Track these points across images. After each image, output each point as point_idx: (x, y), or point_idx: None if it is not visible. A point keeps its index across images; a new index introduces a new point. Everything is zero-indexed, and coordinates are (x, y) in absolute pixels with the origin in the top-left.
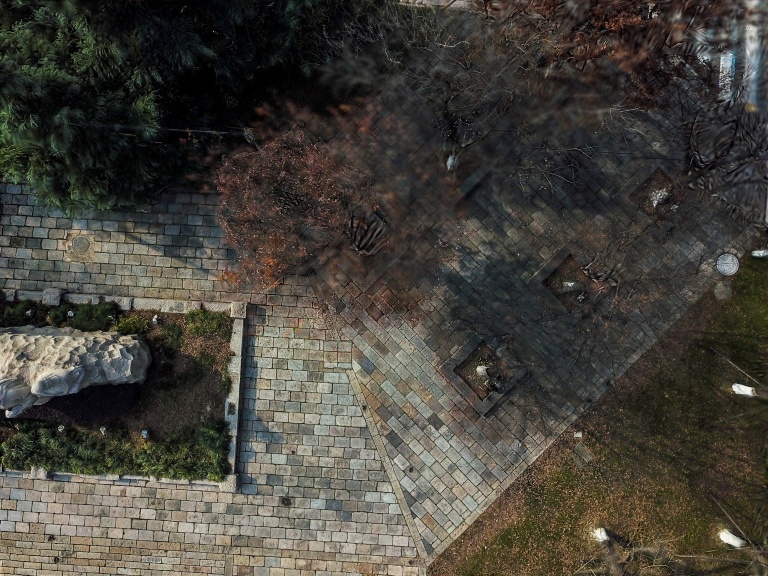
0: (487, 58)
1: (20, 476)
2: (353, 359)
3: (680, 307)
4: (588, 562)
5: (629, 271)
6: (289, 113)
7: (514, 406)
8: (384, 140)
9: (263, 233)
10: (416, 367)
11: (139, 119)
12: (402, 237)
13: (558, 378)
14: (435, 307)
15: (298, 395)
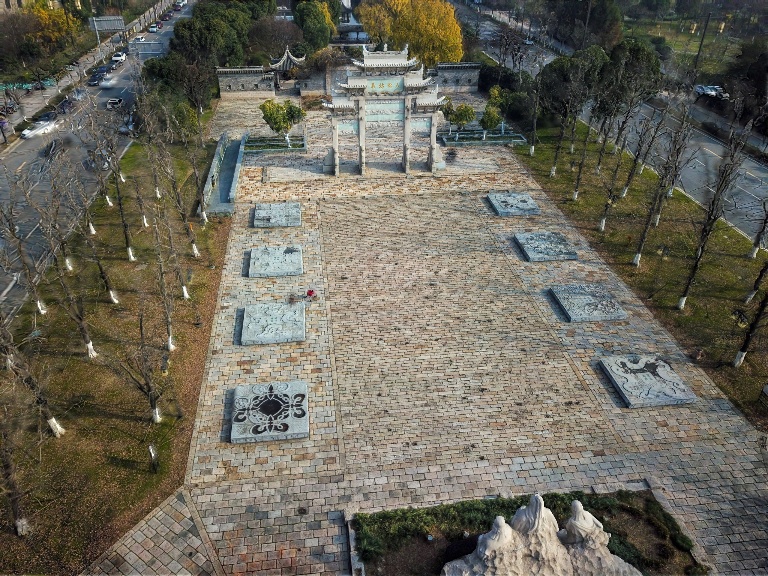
0: None
1: None
2: None
3: None
4: (42, 509)
5: None
6: None
7: None
8: None
9: None
10: None
11: None
12: None
13: None
14: None
15: None
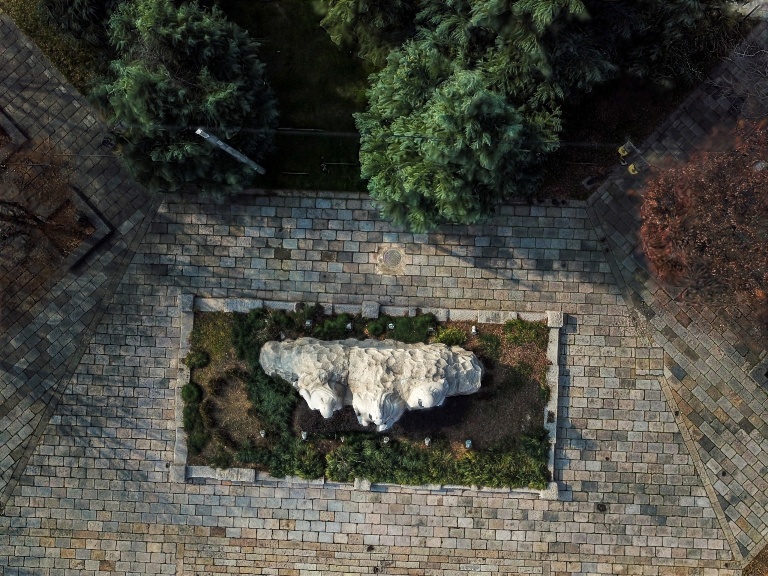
0: None
1: (337, 488)
2: (665, 366)
3: None
4: None
5: None
6: (594, 124)
7: None
8: (688, 149)
9: (743, 247)
10: (726, 372)
11: (537, 135)
12: None
13: None
14: (742, 313)
15: (611, 402)
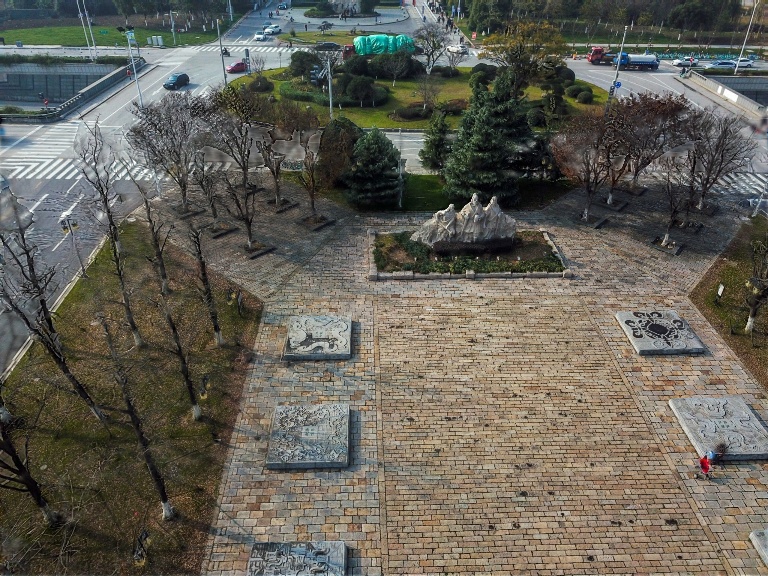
0: (605, 186)
1: (457, 280)
2: (602, 243)
3: None
4: None
5: None
6: None
7: (687, 253)
8: None
9: None
10: None
11: (510, 150)
12: None
13: (700, 246)
14: None
15: None
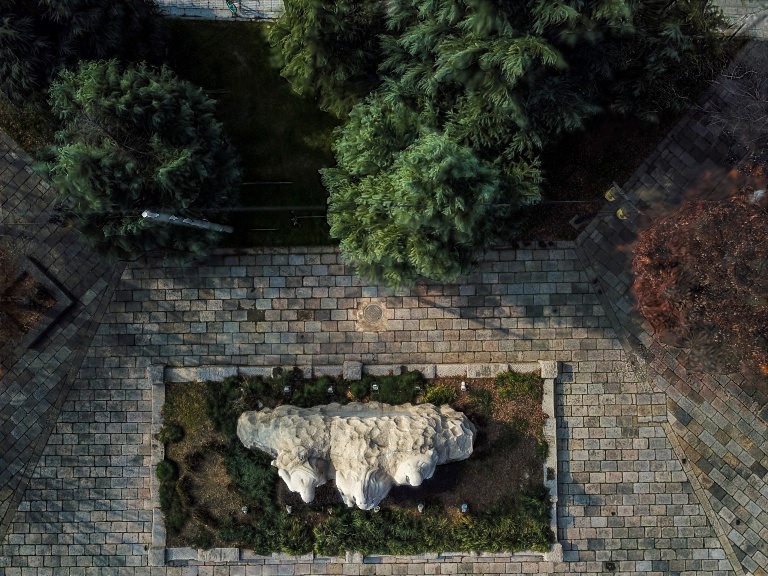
0: None
1: (328, 561)
2: (668, 411)
3: None
4: None
5: None
6: (578, 159)
7: None
8: (679, 180)
9: (746, 310)
10: (733, 414)
11: (516, 188)
12: None
13: None
14: None
15: (613, 453)
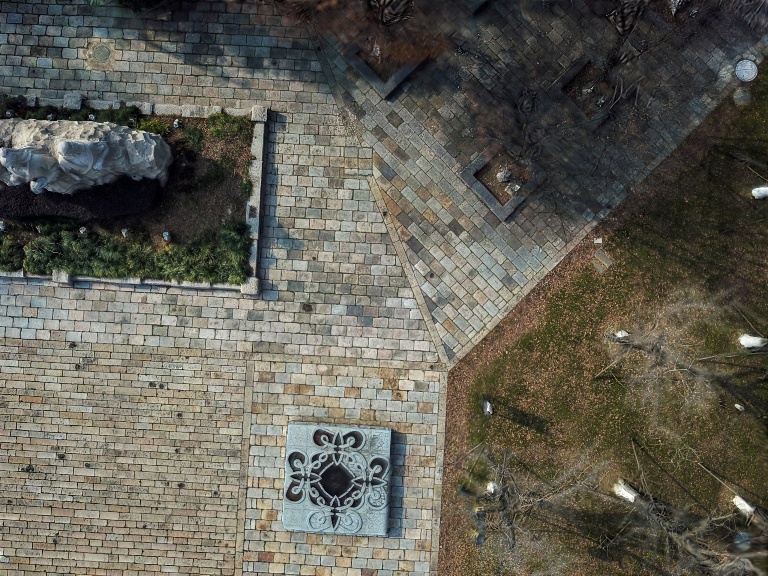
0: None
1: (41, 284)
2: (374, 165)
3: (699, 114)
4: (609, 366)
5: (648, 79)
6: None
7: (534, 213)
8: None
9: None
10: (436, 173)
11: None
12: (422, 44)
13: (578, 185)
14: (455, 114)
15: (319, 201)
